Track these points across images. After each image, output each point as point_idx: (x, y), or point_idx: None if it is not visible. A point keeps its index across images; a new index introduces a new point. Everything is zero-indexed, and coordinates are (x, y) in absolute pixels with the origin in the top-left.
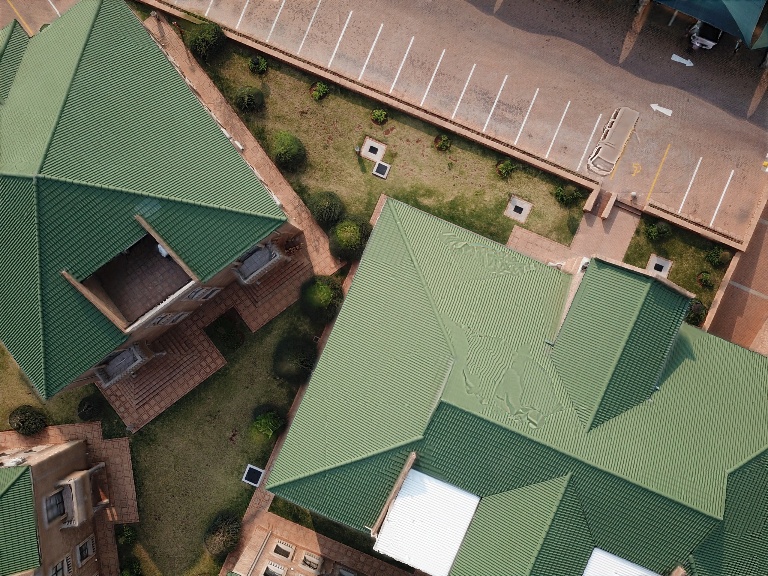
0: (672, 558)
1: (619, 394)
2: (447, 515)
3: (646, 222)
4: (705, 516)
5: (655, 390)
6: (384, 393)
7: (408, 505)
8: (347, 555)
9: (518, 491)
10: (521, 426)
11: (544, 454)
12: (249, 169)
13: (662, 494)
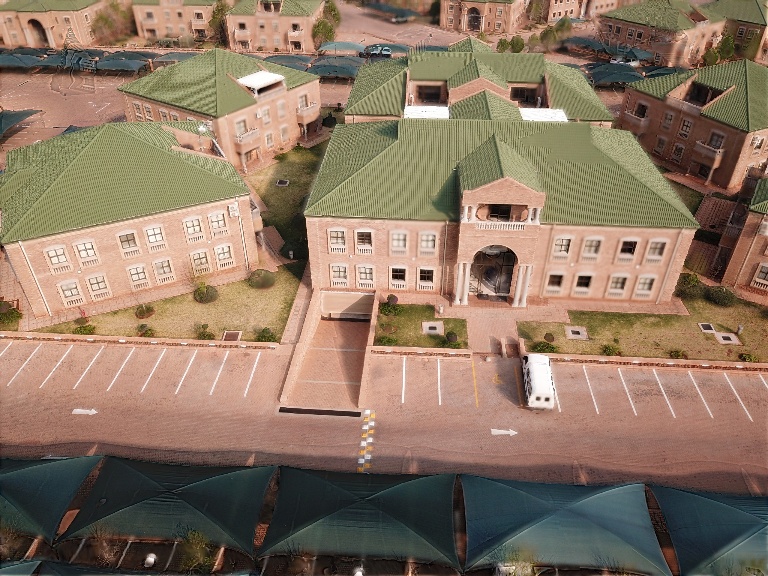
0: None
1: None
2: None
3: None
4: None
5: None
6: None
7: None
8: None
9: None
10: (536, 124)
11: None
12: None
13: (439, 119)
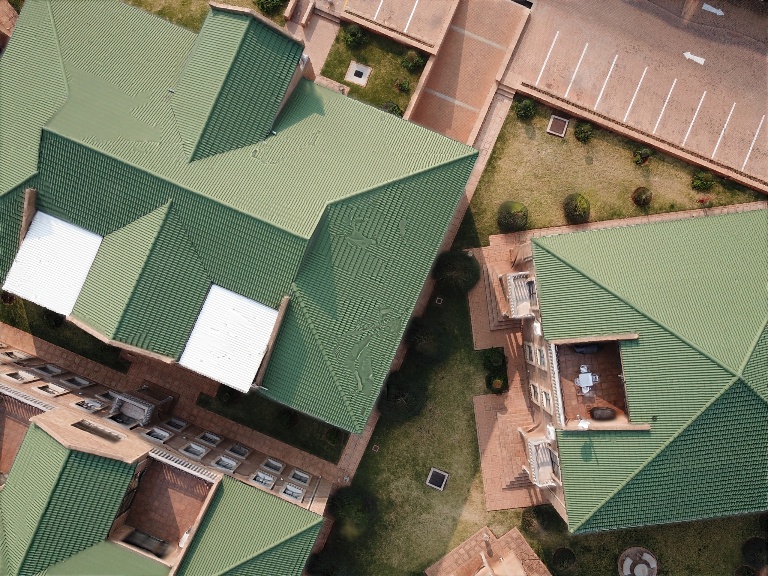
0: (279, 289)
1: (225, 130)
2: (72, 255)
3: (345, 30)
4: (293, 237)
5: (272, 135)
6: (15, 140)
7: (36, 246)
8: (62, 357)
9: (131, 225)
10: (120, 153)
11: (143, 181)
12: None
13: (251, 215)
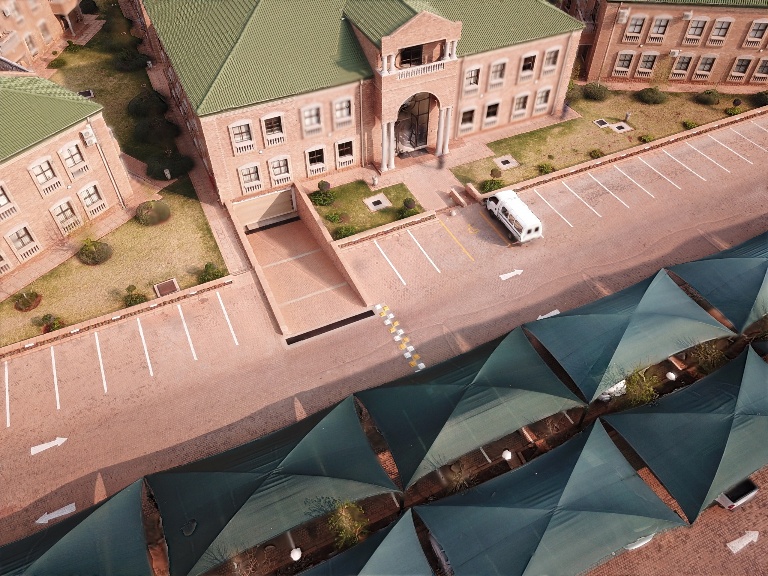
0: None
1: None
2: None
3: None
4: None
5: None
6: None
7: None
8: None
9: None
10: None
11: None
12: (655, 0)
13: None
